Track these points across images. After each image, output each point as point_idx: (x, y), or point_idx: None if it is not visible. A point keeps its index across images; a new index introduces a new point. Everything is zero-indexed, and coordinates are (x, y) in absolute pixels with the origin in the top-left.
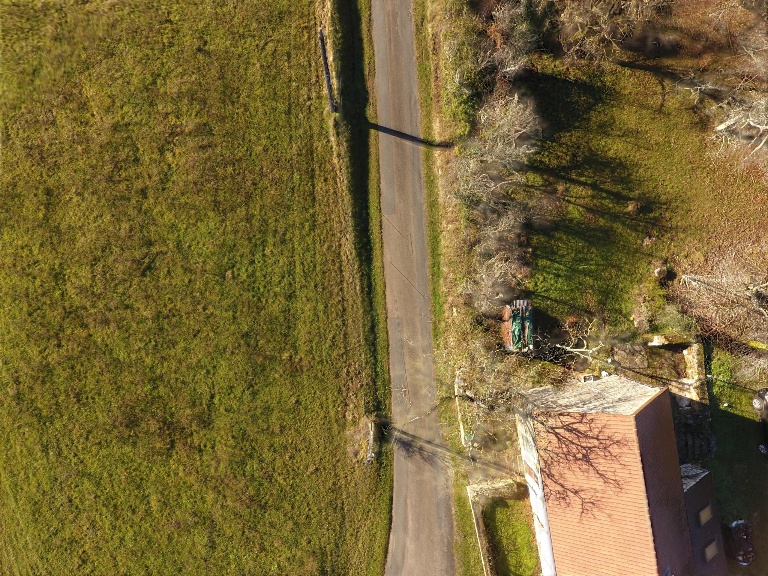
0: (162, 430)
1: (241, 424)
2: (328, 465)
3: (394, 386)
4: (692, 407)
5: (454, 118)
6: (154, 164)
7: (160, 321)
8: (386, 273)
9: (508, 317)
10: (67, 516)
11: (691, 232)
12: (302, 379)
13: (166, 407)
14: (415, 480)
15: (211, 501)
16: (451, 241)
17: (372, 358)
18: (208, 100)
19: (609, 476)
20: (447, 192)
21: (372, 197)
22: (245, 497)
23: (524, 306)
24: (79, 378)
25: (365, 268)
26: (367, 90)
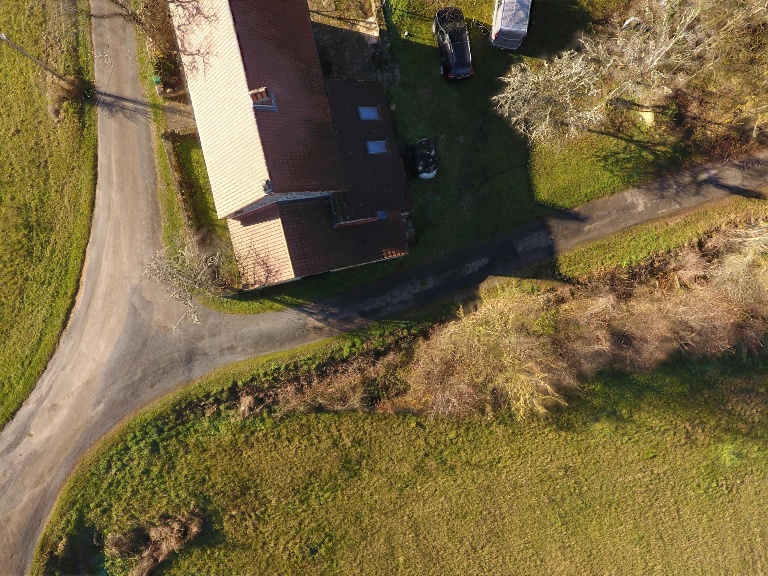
0: None
1: None
2: (30, 126)
3: (97, 53)
4: None
5: None
6: None
7: None
8: None
9: None
10: None
11: None
12: (2, 48)
13: None
14: (118, 137)
15: None
16: None
17: (73, 27)
18: None
19: (210, 13)
20: None
21: None
22: None
23: None
24: None
25: None
26: None
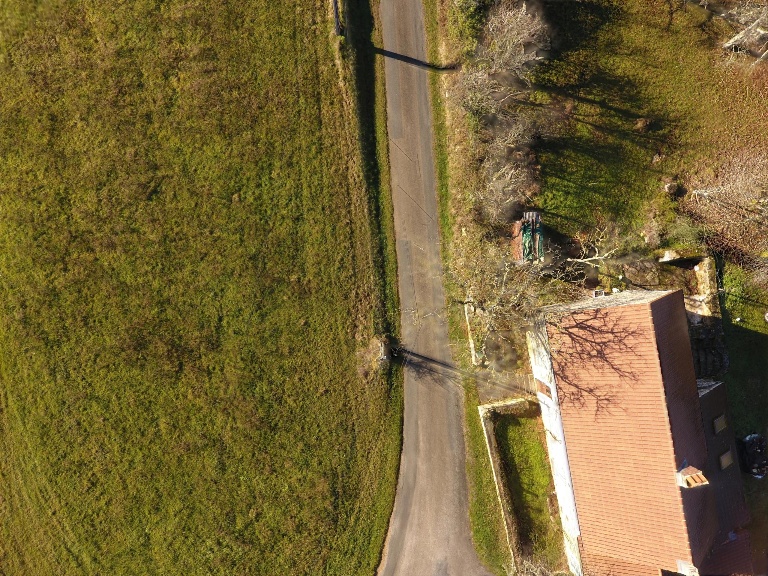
0: (170, 353)
1: (250, 346)
2: (338, 386)
3: (403, 308)
4: (704, 323)
5: (461, 36)
6: (159, 89)
7: (167, 245)
8: (394, 196)
9: (518, 231)
10: (76, 439)
11: (701, 148)
12: (311, 301)
13: (174, 330)
14: (426, 401)
15: (220, 423)
16: (459, 162)
17: (381, 280)
18: (212, 25)
19: (624, 369)
20: (454, 114)
21: (379, 121)
22: (255, 419)
23: (534, 218)
24: (86, 302)
25: (373, 191)
26: (372, 15)
